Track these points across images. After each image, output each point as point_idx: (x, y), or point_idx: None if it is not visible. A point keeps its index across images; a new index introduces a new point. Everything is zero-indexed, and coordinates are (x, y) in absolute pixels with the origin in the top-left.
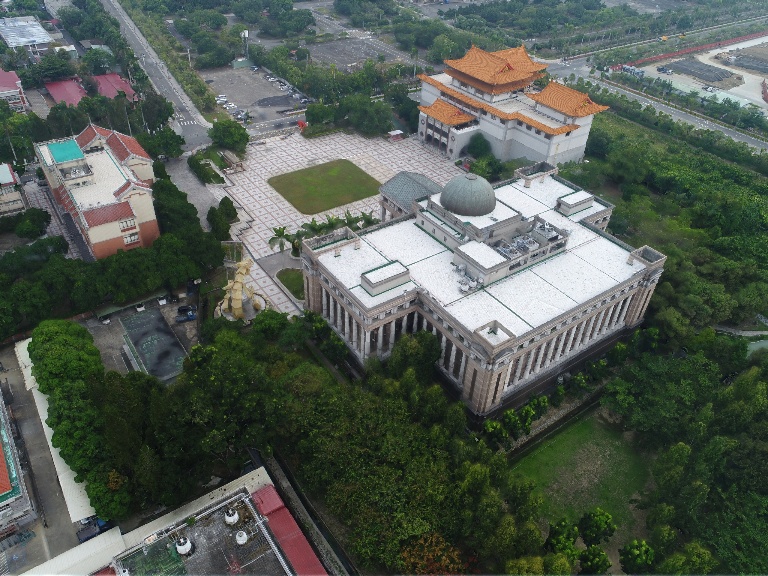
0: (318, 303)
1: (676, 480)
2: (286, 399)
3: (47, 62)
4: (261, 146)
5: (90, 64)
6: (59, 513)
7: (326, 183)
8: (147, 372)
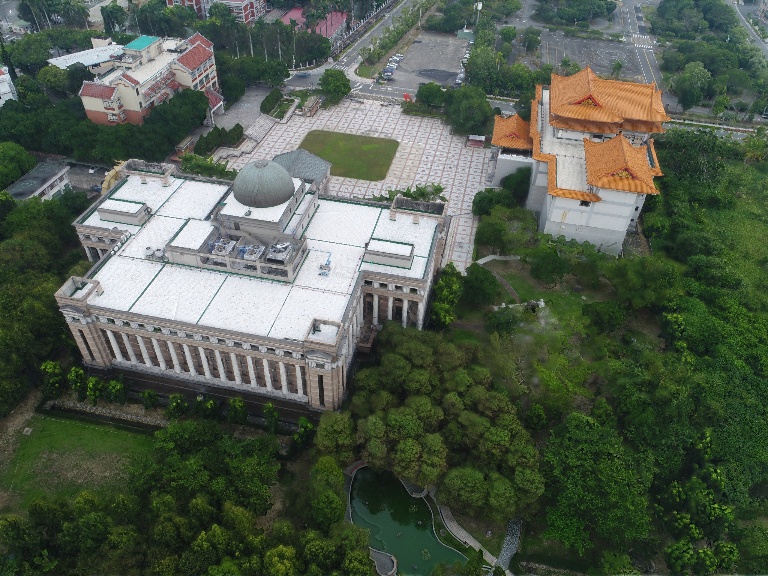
0: None
1: (29, 508)
2: None
3: None
4: (357, 104)
5: None
6: None
7: (345, 152)
8: None
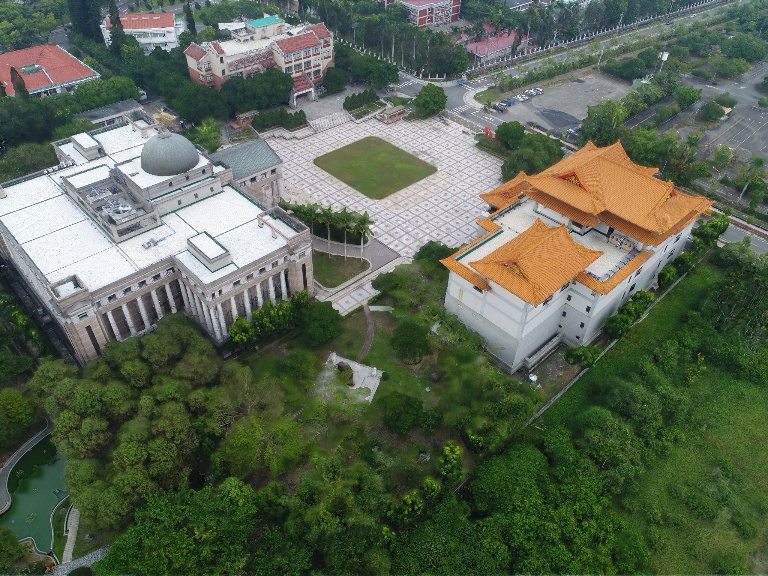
0: None
1: None
2: (17, 148)
3: None
4: (442, 125)
5: (517, 20)
6: None
7: (376, 164)
8: None
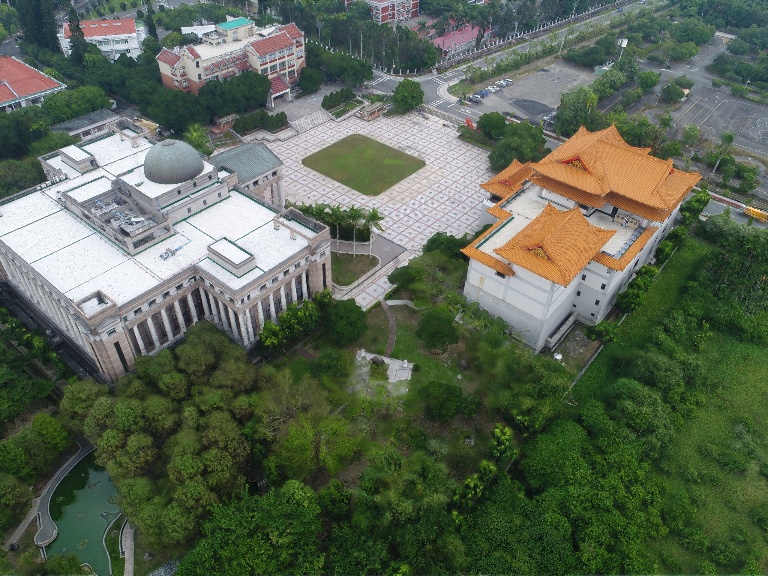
0: None
1: None
2: None
3: (455, 0)
4: (421, 119)
5: (477, 14)
6: None
7: (365, 161)
8: None
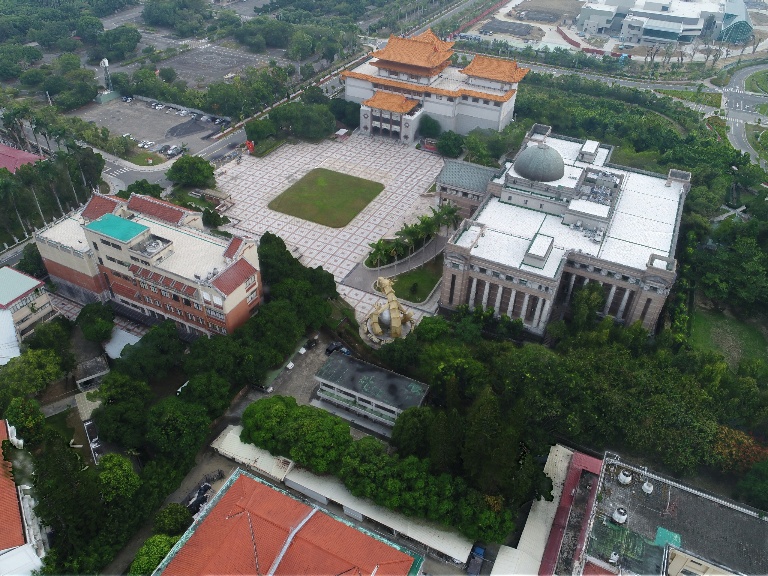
0: (464, 296)
1: None
2: None
3: None
4: (224, 176)
5: None
6: (427, 567)
7: (326, 194)
8: (399, 409)
